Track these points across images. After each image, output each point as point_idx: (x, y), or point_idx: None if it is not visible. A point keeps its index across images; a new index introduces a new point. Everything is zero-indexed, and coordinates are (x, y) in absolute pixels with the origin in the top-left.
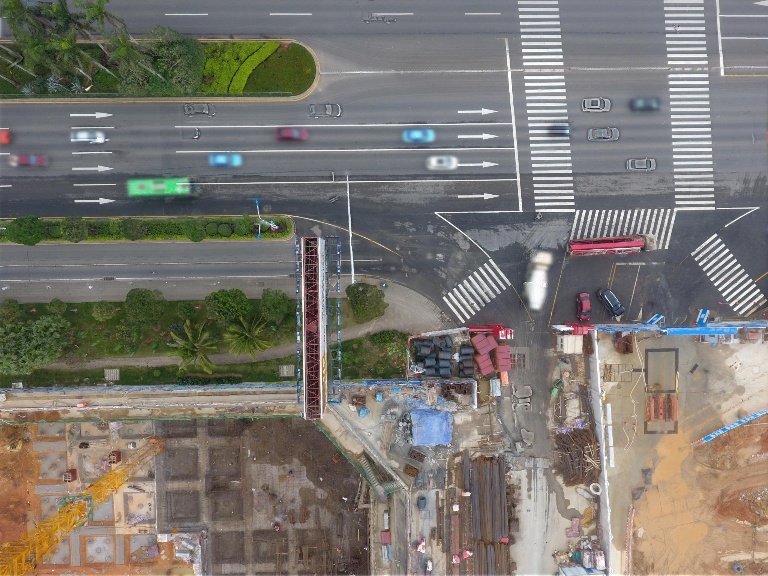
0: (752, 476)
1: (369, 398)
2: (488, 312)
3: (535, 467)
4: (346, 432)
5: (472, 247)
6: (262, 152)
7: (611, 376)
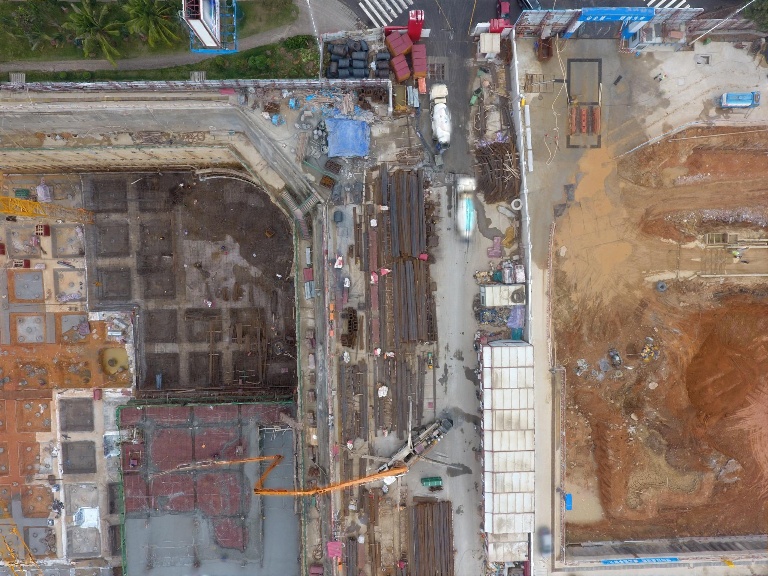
0: (678, 198)
1: (283, 107)
2: (406, 19)
3: (455, 184)
4: (267, 166)
5: None
6: None
7: (532, 87)
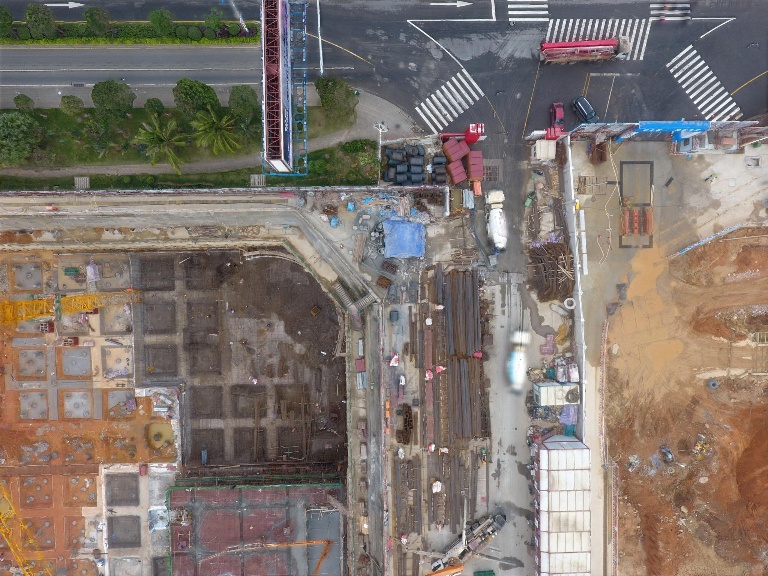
0: (728, 295)
1: (341, 209)
2: (461, 123)
3: (509, 282)
4: (320, 259)
5: (445, 56)
6: None
7: (585, 188)
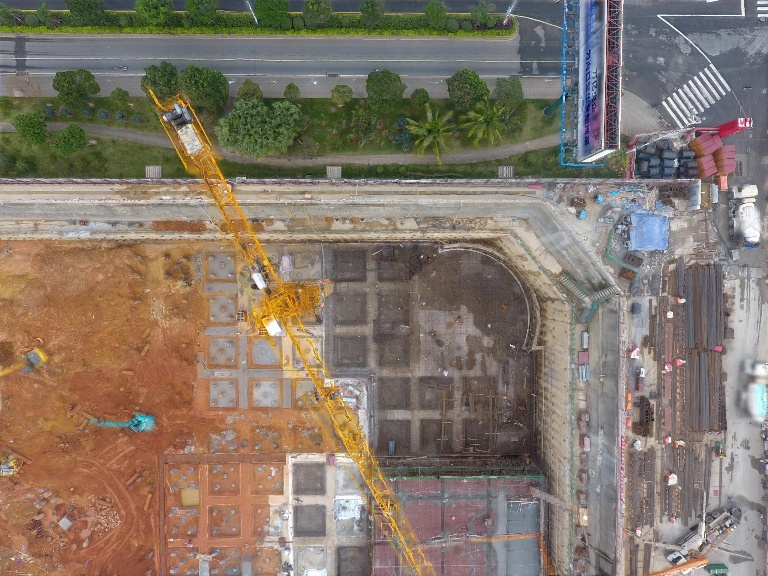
0: None
1: (587, 202)
2: (707, 118)
3: (748, 277)
4: (546, 251)
5: (693, 51)
6: None
7: None
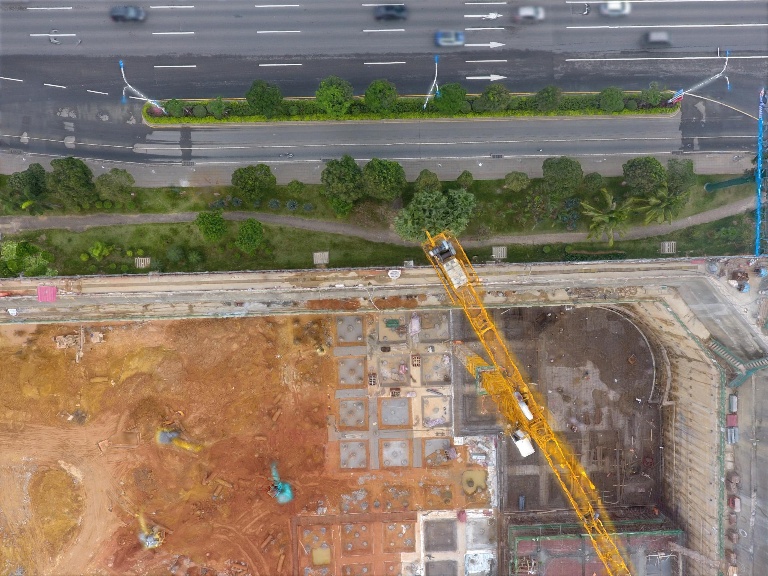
0: None
1: None
2: None
3: None
4: (694, 317)
5: None
6: (650, 28)
7: None
